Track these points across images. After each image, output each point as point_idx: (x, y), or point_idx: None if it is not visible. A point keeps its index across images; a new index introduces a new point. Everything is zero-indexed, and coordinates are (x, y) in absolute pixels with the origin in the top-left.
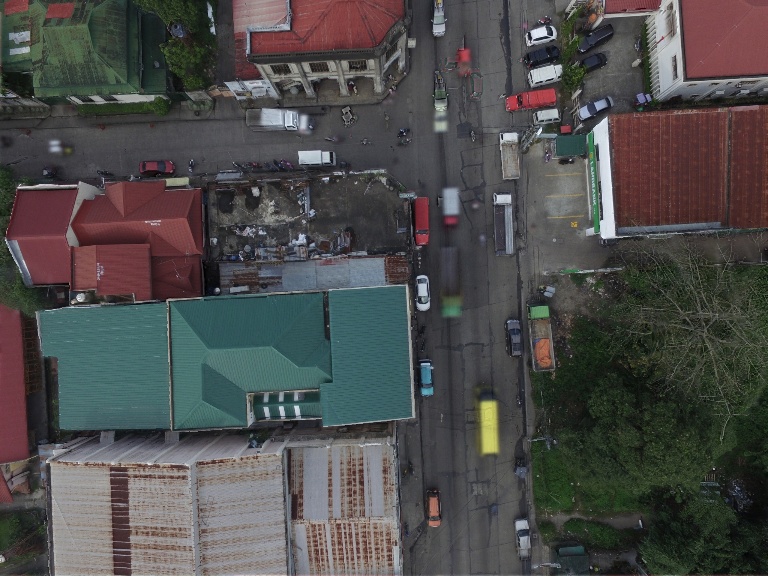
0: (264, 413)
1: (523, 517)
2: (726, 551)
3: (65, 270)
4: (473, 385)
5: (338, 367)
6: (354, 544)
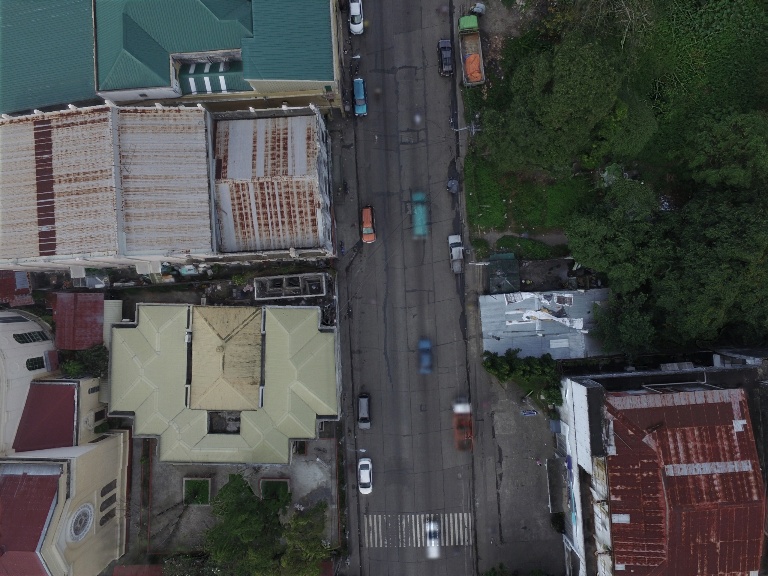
0: (190, 87)
1: (456, 234)
2: (646, 224)
3: None
4: (407, 107)
5: (259, 24)
6: (278, 207)
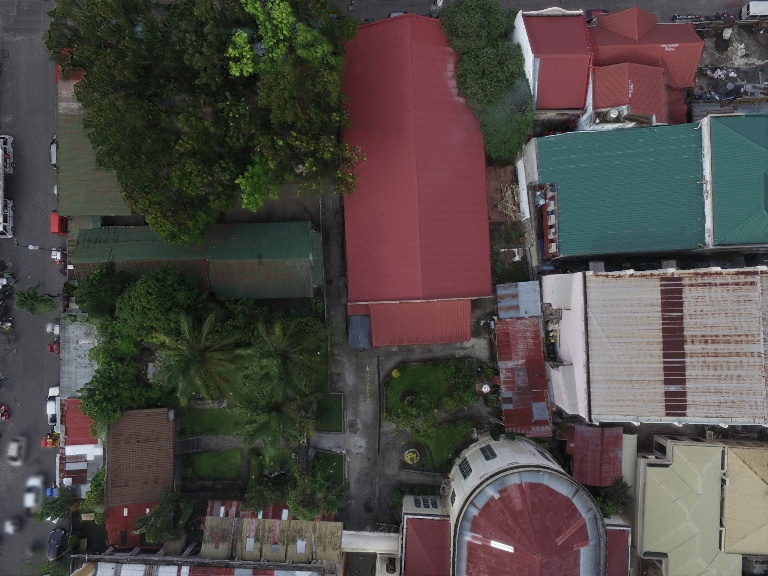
0: None
1: None
2: None
3: (573, 94)
4: None
5: None
6: None
